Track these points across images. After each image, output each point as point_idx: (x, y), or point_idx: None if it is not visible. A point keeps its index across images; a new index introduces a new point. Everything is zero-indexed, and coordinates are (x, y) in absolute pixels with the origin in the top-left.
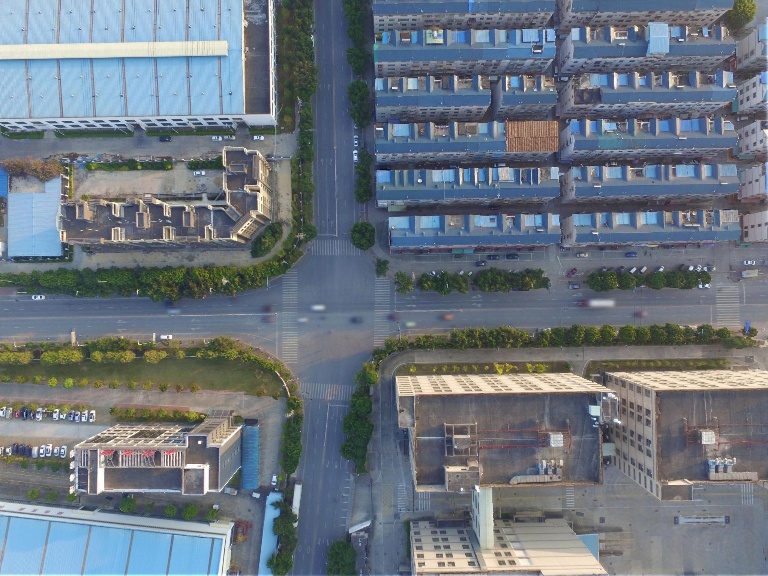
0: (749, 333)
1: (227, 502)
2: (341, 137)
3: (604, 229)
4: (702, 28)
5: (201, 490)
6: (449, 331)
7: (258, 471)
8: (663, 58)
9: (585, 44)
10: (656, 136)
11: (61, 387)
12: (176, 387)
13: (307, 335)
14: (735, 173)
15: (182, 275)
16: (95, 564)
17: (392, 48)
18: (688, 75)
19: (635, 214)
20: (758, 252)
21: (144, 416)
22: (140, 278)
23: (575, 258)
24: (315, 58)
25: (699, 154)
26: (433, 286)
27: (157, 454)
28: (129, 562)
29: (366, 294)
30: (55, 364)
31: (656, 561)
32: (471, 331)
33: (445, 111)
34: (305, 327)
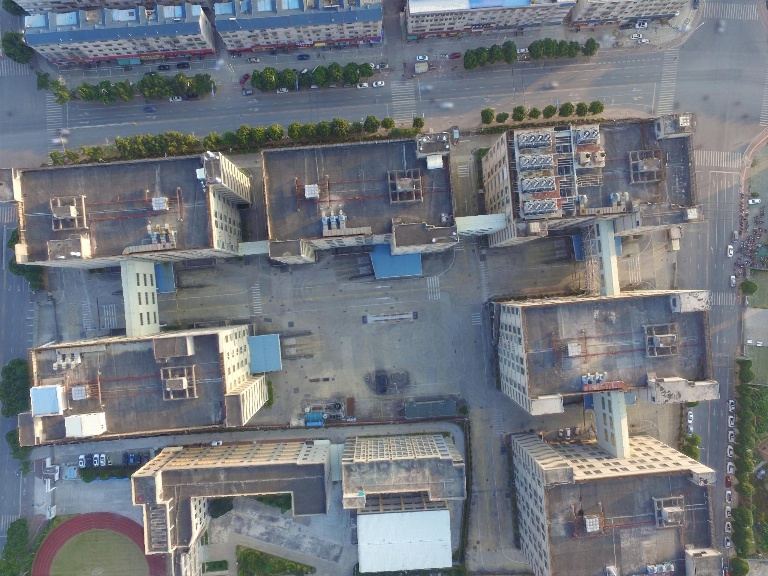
0: (415, 123)
1: None
2: None
3: (244, 16)
4: None
5: None
6: None
7: None
8: None
9: None
10: None
11: None
12: None
13: None
14: None
15: None
16: None
17: None
18: None
19: None
20: (431, 48)
21: None
22: None
23: (248, 64)
24: None
25: None
26: (92, 94)
27: None
28: None
29: (38, 114)
30: None
31: (347, 361)
32: (136, 138)
33: None
34: None
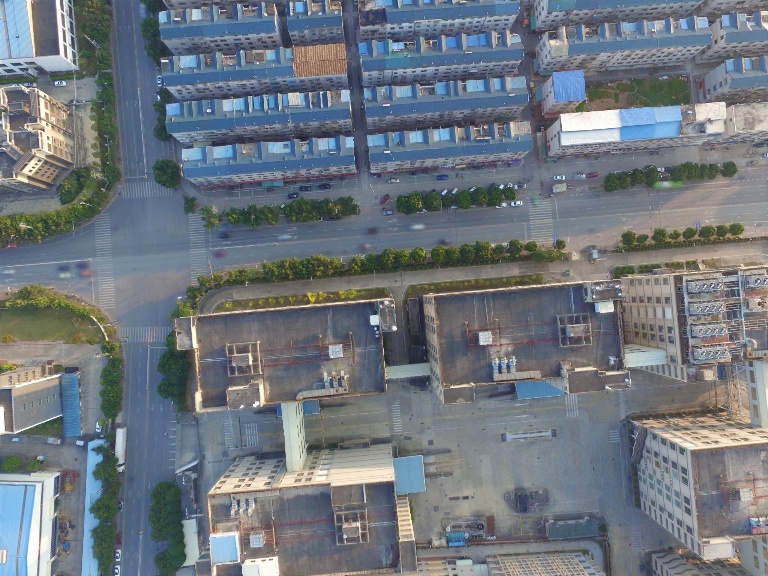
0: (558, 245)
1: (52, 453)
2: (145, 78)
3: (397, 148)
4: None
5: None
6: (261, 264)
7: (81, 419)
8: None
9: None
10: (443, 52)
11: None
12: None
13: (123, 279)
14: (524, 85)
15: None
16: None
17: None
18: None
19: (427, 131)
20: (568, 167)
21: None
22: None
23: (387, 184)
24: (113, 0)
25: (498, 72)
26: (240, 219)
27: None
28: None
29: (181, 234)
30: None
31: (486, 479)
32: (282, 262)
33: (238, 42)
34: (121, 271)
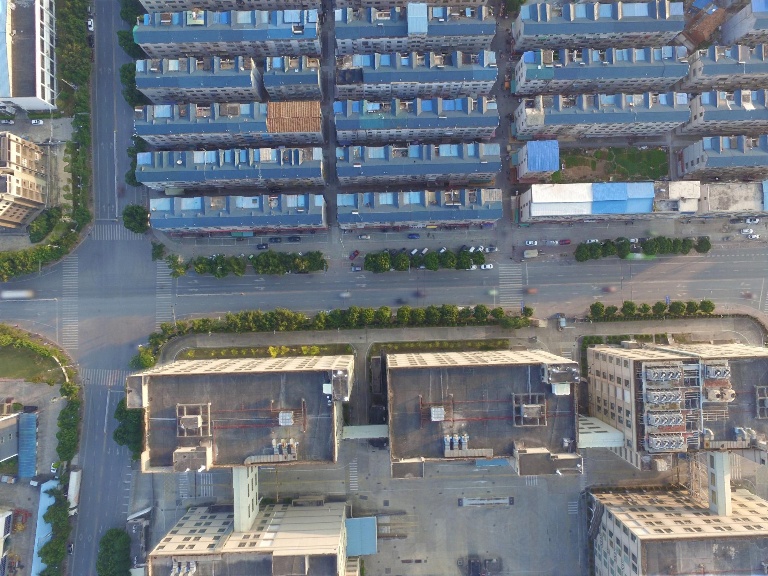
0: (525, 313)
1: (6, 491)
2: (122, 121)
3: (366, 209)
4: (465, 8)
5: None
6: None
7: (37, 459)
8: (428, 38)
9: (345, 24)
10: (417, 116)
11: None
12: None
13: (88, 320)
14: (498, 152)
15: None
16: None
17: (151, 29)
18: (451, 55)
19: (397, 194)
20: (540, 232)
21: None
22: None
23: (358, 240)
24: (95, 42)
25: (474, 135)
26: (207, 269)
27: None
28: None
29: (148, 278)
30: None
31: (440, 544)
32: (246, 314)
33: (214, 93)
34: (86, 312)
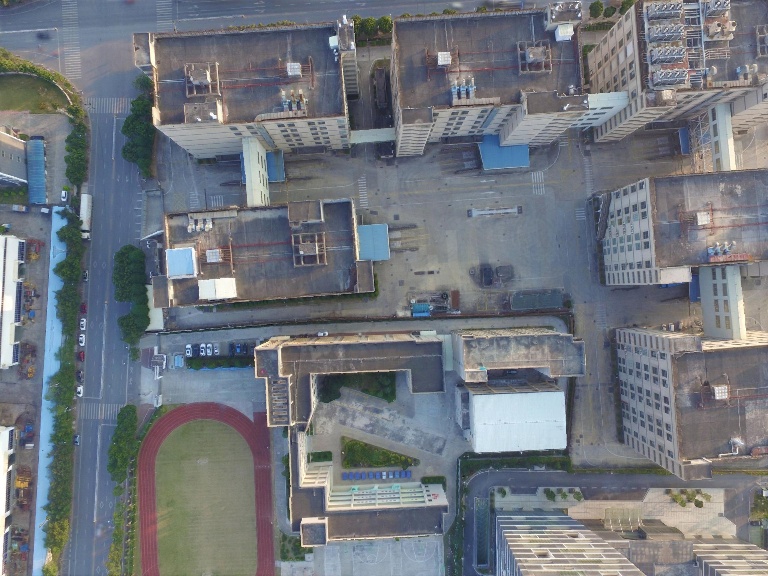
0: None
1: (18, 222)
2: None
3: None
4: None
5: None
6: None
7: (46, 187)
8: None
9: None
10: None
11: None
12: None
13: (90, 50)
14: None
15: None
16: None
17: None
18: None
19: None
20: None
21: None
22: None
23: None
24: None
25: None
26: None
27: None
28: None
29: (148, 6)
30: None
31: (452, 254)
32: None
33: None
34: (87, 42)
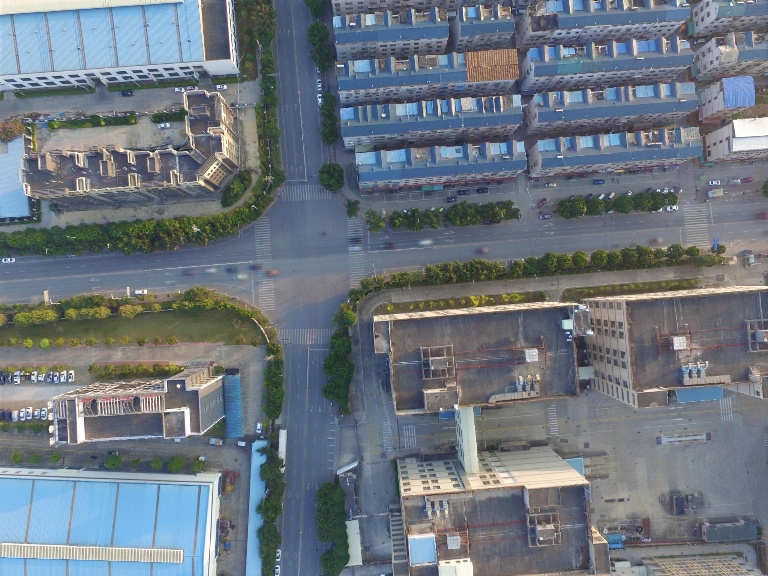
0: (718, 250)
1: (213, 453)
2: (304, 82)
3: (569, 153)
4: None
5: (183, 433)
6: (423, 267)
7: (242, 420)
8: None
9: None
10: (614, 58)
11: (38, 349)
12: (154, 340)
13: (283, 281)
14: (693, 91)
15: (152, 227)
16: (82, 519)
17: None
18: None
19: (598, 136)
20: (722, 172)
21: (123, 371)
22: (110, 232)
23: (544, 189)
24: (273, 4)
25: (658, 77)
26: (404, 223)
27: (136, 401)
28: (116, 515)
29: (339, 237)
30: (30, 326)
31: (641, 482)
32: (445, 265)
33: (405, 47)
34: (280, 274)
